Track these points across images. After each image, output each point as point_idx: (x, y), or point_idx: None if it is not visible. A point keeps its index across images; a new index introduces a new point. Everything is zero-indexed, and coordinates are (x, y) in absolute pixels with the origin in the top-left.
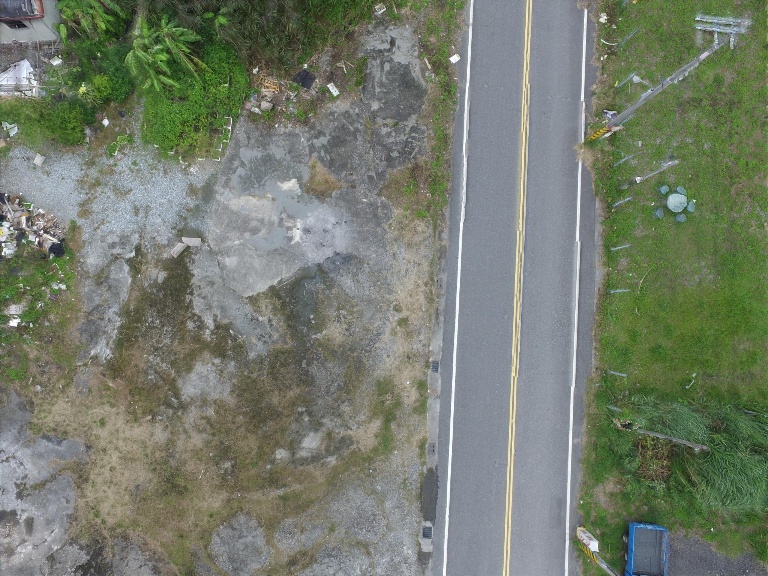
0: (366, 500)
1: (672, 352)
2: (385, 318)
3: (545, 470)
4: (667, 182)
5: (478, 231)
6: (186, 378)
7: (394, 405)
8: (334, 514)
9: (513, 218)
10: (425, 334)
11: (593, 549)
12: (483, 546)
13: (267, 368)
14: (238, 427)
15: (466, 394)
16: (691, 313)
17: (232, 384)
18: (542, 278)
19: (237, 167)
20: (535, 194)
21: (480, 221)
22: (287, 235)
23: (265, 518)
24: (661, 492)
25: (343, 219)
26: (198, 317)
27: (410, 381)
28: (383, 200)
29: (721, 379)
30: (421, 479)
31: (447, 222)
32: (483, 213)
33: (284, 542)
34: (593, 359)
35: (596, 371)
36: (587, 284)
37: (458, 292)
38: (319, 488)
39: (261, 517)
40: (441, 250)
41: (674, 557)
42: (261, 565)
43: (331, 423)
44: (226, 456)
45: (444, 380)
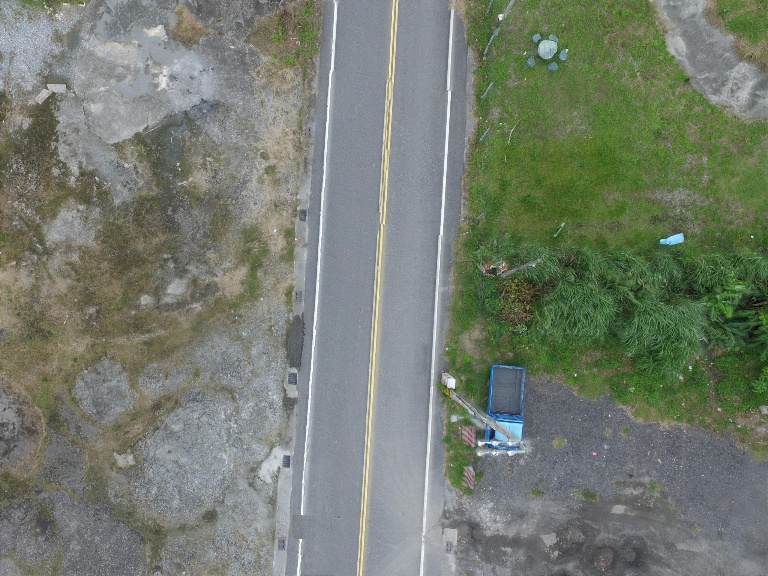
0: (231, 346)
1: (541, 202)
2: (252, 166)
3: (411, 317)
4: (539, 31)
5: (348, 80)
6: (51, 224)
7: (260, 253)
8: (199, 359)
9: (383, 66)
10: (293, 182)
11: (449, 386)
12: (347, 391)
13: (132, 215)
14: (103, 273)
15: (333, 242)
16: (561, 163)
17: (97, 231)
18: (411, 127)
19: (103, 13)
20: (406, 42)
21: (350, 70)
22: (153, 82)
23: (130, 363)
24: (525, 338)
25: (210, 66)
26: (63, 164)
27: (277, 229)
28: (251, 47)
29: (590, 229)
30: (287, 326)
31: (317, 71)
32: (353, 61)
33: (149, 387)
34: (462, 208)
35: (464, 220)
36: (457, 134)
37: (326, 140)
38: (184, 334)
39: (126, 362)
40: (310, 99)
41: (537, 402)
42: (125, 409)
43: (197, 270)
44: (91, 302)
45: (311, 229)
